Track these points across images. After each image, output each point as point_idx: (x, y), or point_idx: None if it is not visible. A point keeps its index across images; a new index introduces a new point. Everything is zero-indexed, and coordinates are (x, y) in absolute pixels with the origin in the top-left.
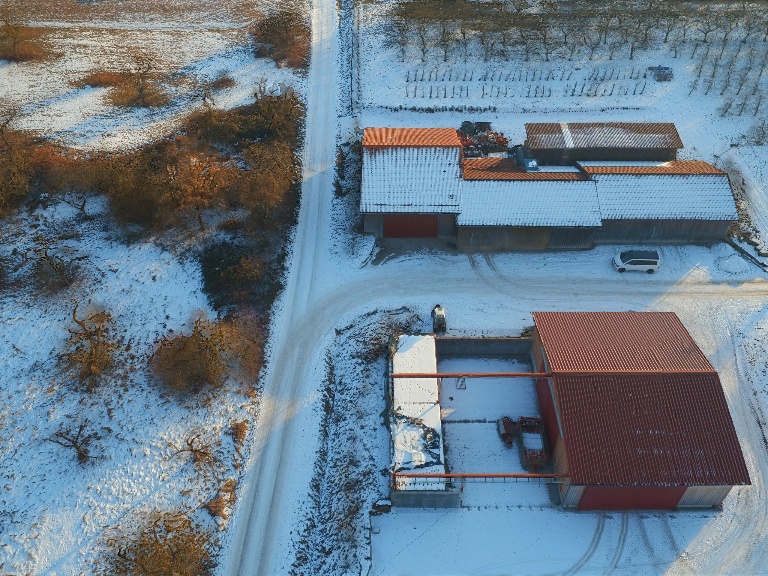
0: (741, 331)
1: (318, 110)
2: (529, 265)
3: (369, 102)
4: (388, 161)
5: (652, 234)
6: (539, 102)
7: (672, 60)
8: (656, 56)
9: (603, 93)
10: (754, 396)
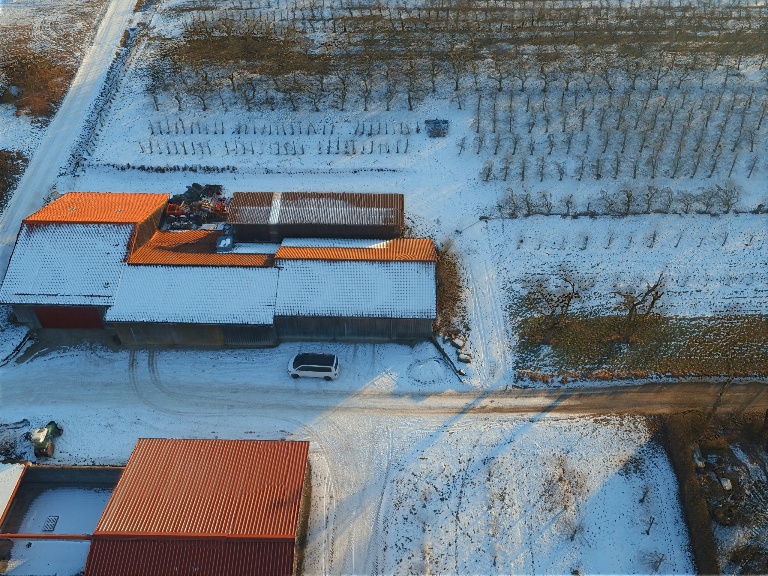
0: (401, 462)
1: (40, 167)
2: (195, 366)
3: (98, 159)
4: (47, 240)
5: (345, 330)
6: (286, 161)
7: (455, 112)
8: (440, 107)
9: (364, 151)
10: (383, 552)
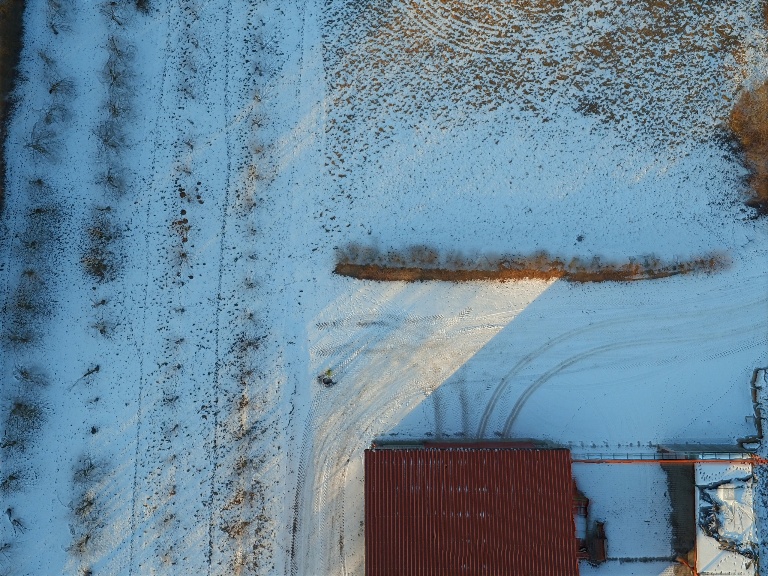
0: None
1: None
2: None
3: None
4: None
5: None
6: None
7: None
8: None
9: None
10: None
